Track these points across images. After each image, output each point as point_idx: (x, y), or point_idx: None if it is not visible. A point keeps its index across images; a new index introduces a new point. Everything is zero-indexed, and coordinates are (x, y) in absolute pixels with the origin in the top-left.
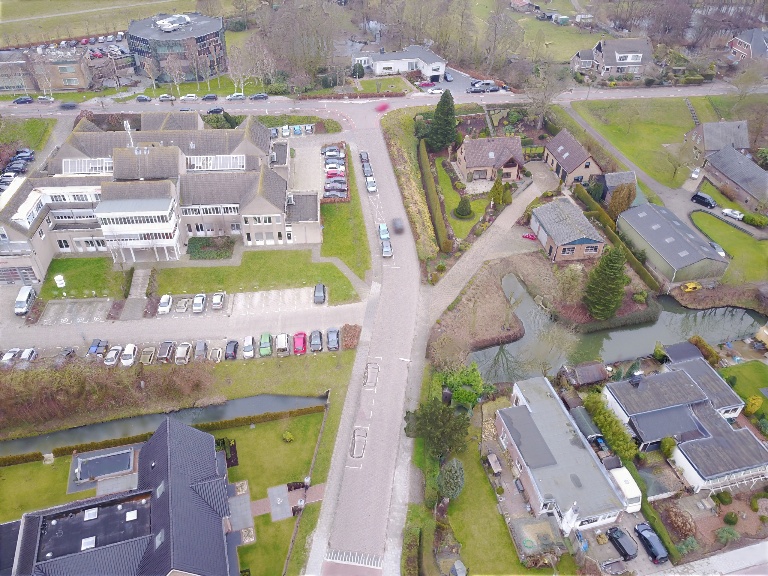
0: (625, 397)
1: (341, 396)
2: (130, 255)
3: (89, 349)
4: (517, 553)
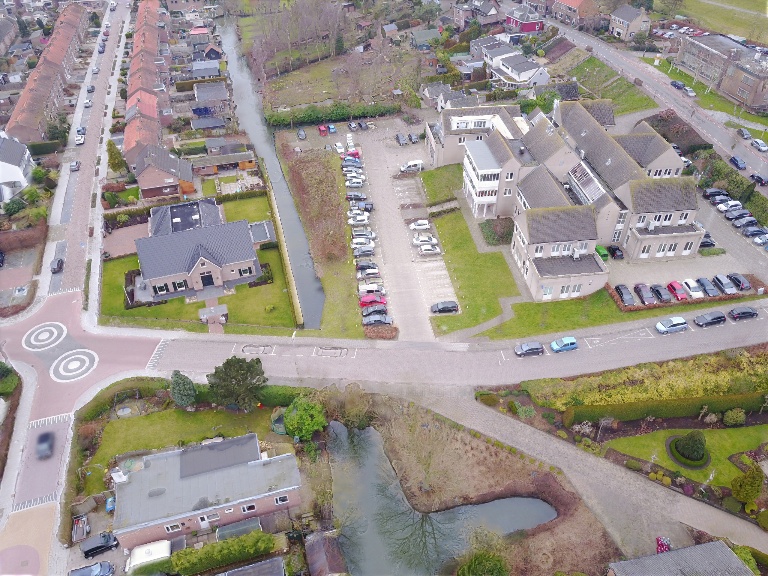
0: (256, 575)
1: (308, 334)
2: None
3: None
4: None
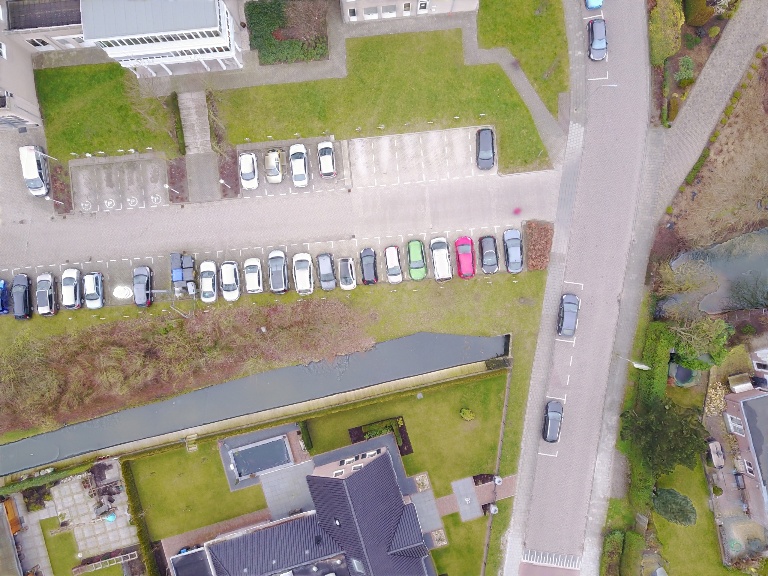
0: None
1: (529, 352)
2: (161, 68)
3: (172, 272)
4: (722, 557)
